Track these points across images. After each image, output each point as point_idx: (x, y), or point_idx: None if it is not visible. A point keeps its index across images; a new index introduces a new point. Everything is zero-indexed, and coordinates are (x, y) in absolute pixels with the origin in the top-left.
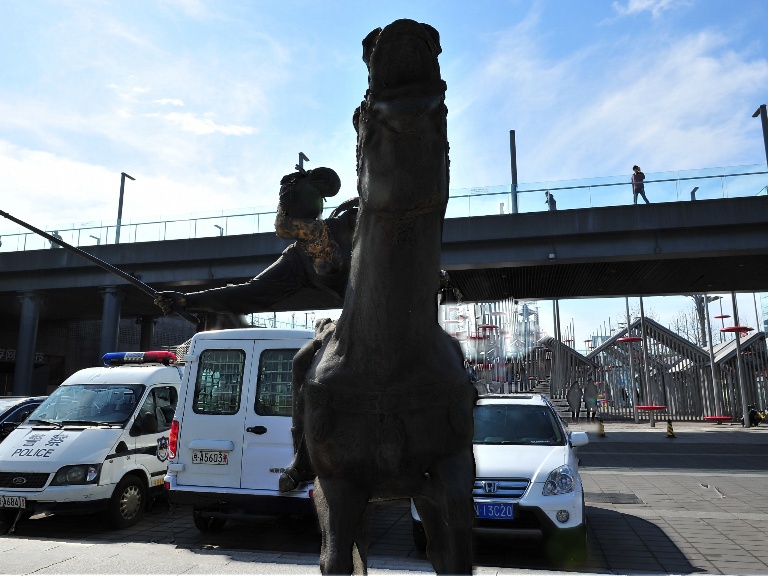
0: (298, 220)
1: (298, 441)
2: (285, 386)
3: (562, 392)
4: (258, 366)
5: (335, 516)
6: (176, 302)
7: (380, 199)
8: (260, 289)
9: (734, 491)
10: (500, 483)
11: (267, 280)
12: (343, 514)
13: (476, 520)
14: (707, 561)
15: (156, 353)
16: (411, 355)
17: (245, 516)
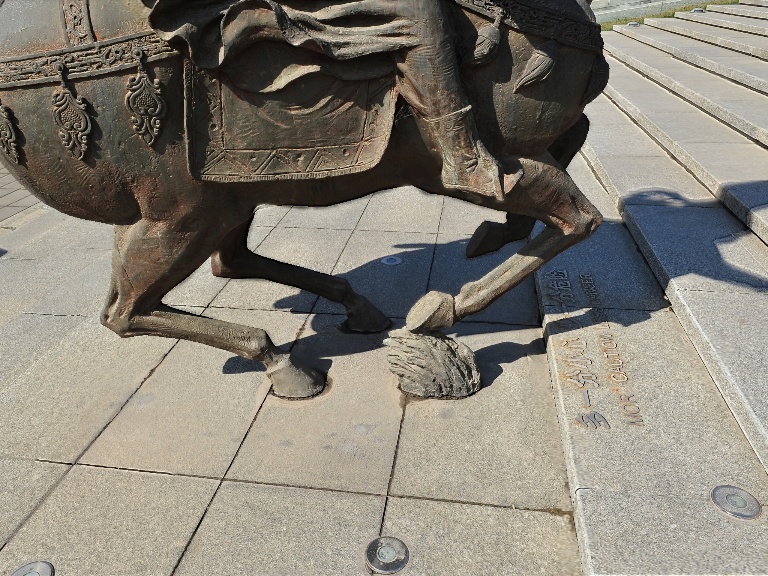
0: None
1: (471, 127)
2: None
3: None
4: None
5: None
6: None
7: None
8: None
9: None
10: None
11: None
12: None
13: None
14: None
15: None
16: None
17: None
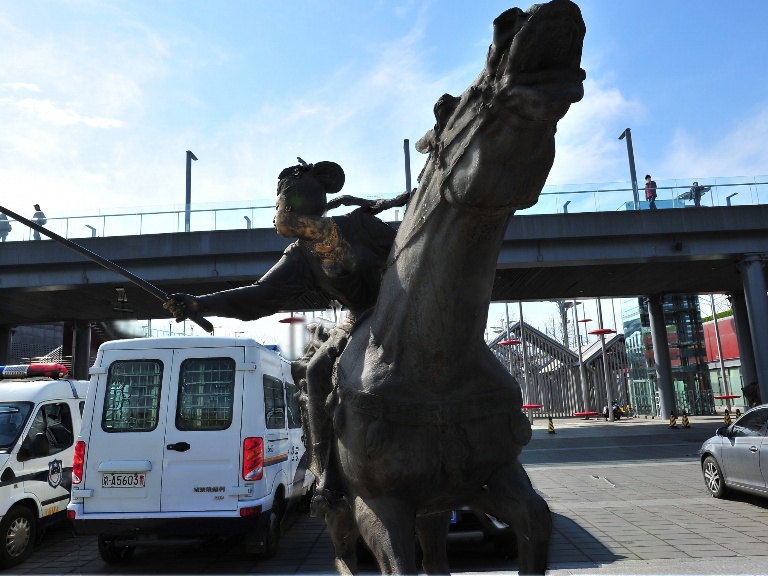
0: (304, 217)
1: (324, 458)
2: (208, 398)
3: None
4: (178, 377)
5: (396, 539)
6: (188, 306)
7: (480, 193)
8: (269, 292)
9: (622, 480)
10: None
11: (275, 282)
12: (403, 536)
13: None
14: (624, 548)
15: (43, 366)
16: (470, 361)
17: (167, 542)
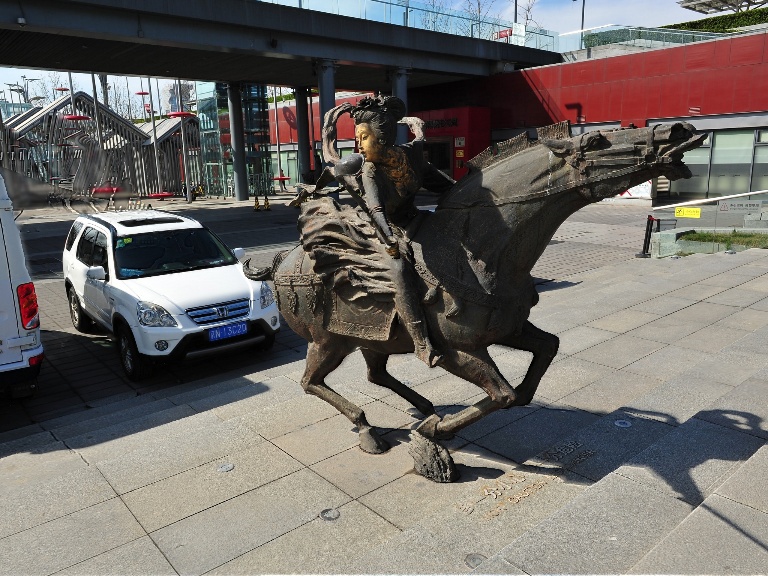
0: (390, 149)
1: (423, 331)
2: None
3: (88, 191)
4: None
5: None
6: None
7: None
8: None
9: None
10: (228, 307)
11: None
12: None
13: (216, 341)
14: None
15: None
16: None
17: None
